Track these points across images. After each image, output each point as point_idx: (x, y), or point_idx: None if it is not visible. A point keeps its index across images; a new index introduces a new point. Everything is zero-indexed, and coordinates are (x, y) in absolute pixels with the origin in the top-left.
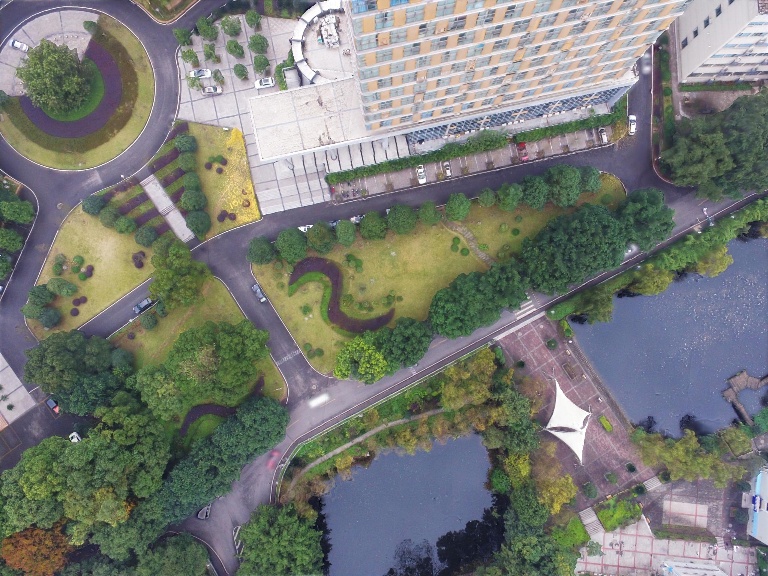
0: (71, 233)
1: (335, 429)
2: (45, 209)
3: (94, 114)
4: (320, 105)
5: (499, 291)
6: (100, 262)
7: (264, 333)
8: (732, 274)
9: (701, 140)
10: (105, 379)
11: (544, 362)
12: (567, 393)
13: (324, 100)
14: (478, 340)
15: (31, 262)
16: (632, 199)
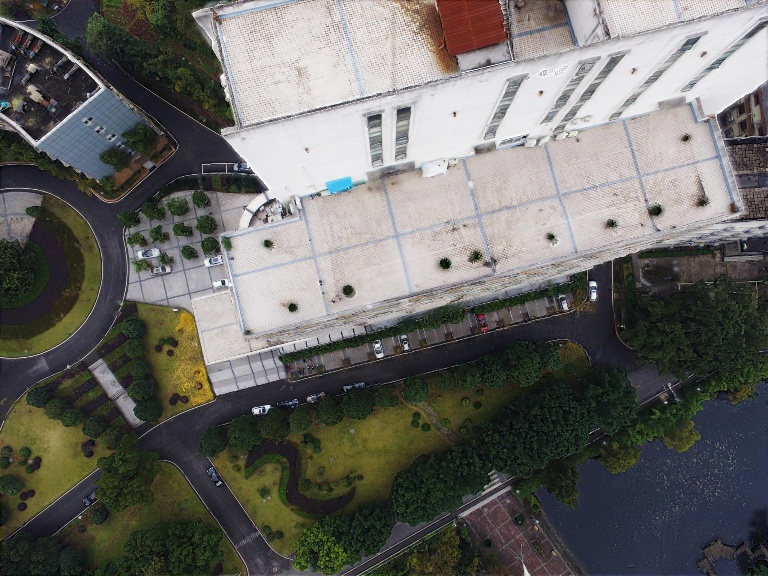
0: (17, 423)
1: None
2: None
3: (39, 299)
4: None
5: (461, 475)
6: (48, 453)
7: (216, 537)
8: (702, 438)
9: (660, 328)
10: None
11: (512, 539)
12: (537, 571)
13: None
14: (443, 517)
15: None
16: (594, 377)
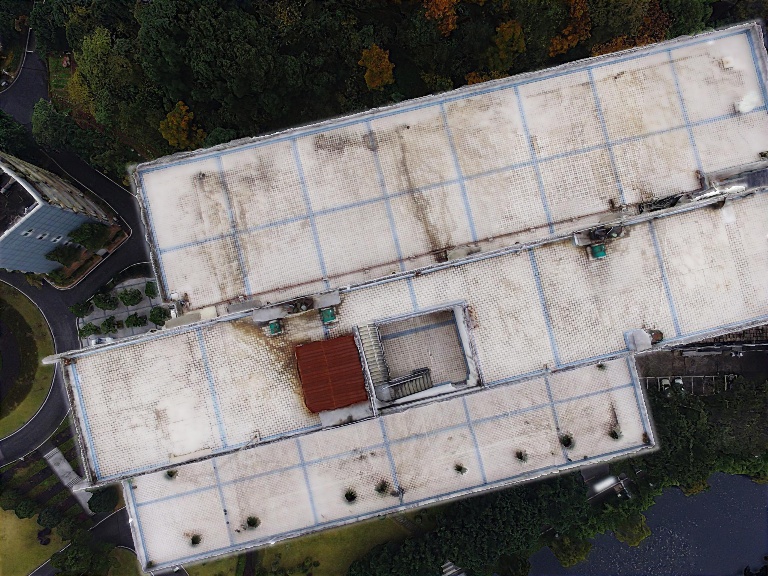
0: None
1: None
2: None
3: None
4: None
5: (414, 568)
6: (5, 540)
7: None
8: (655, 525)
9: None
10: None
11: None
12: None
13: None
14: None
15: None
16: None
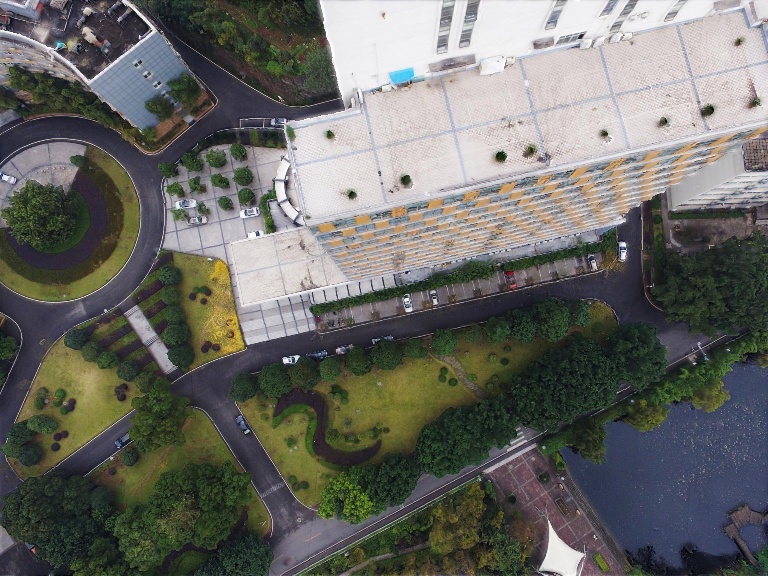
0: (54, 366)
1: (320, 565)
2: (28, 341)
3: (79, 246)
4: (302, 249)
5: (488, 428)
6: (82, 395)
7: (245, 479)
8: (730, 402)
9: (692, 282)
10: (83, 524)
11: (536, 496)
12: (561, 529)
13: (306, 244)
14: (467, 473)
15: (13, 396)
16: (623, 334)
